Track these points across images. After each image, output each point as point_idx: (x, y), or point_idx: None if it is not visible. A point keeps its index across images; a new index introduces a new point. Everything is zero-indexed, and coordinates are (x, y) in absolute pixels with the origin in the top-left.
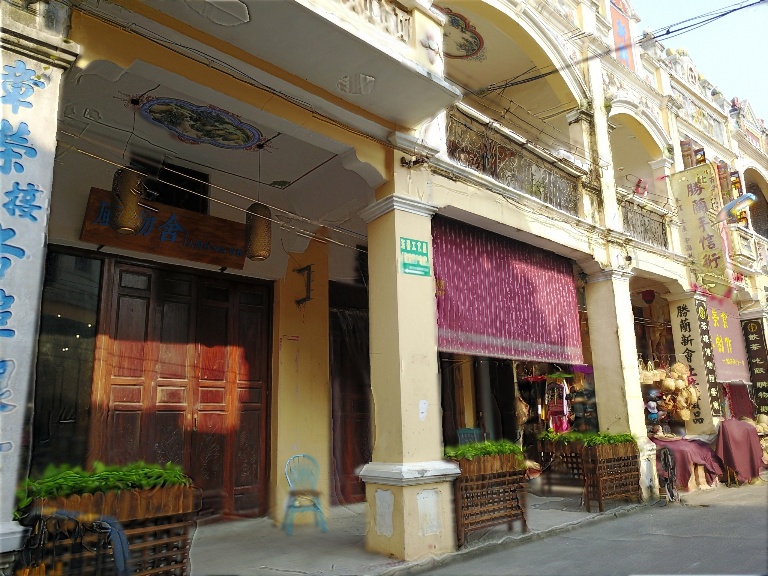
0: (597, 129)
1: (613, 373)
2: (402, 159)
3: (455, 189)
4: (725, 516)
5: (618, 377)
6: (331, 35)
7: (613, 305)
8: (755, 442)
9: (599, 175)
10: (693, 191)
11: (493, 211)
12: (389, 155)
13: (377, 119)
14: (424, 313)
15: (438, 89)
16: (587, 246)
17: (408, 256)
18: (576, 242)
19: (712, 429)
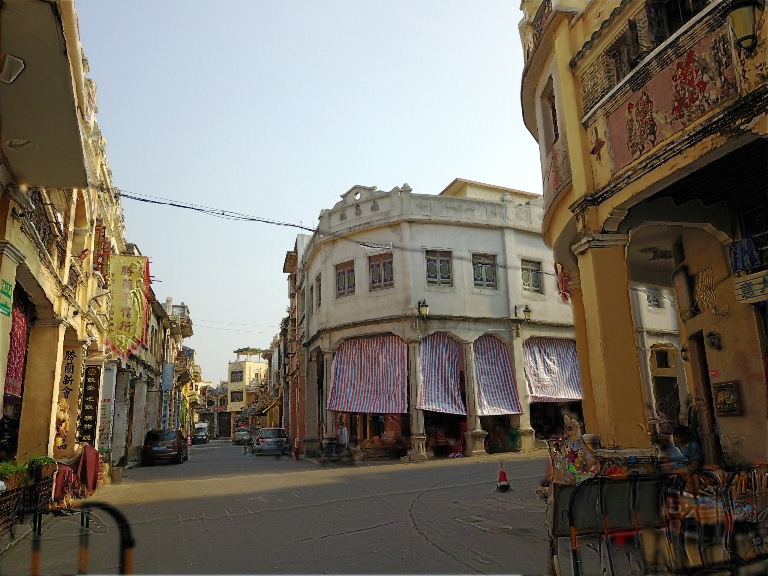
0: (73, 199)
1: (42, 406)
2: (13, 209)
3: (21, 238)
4: (119, 513)
5: (46, 409)
6: (68, 130)
7: (55, 349)
8: (97, 463)
9: (67, 238)
10: (126, 272)
11: (30, 261)
12: (5, 202)
13: (11, 171)
14: (3, 349)
15: (85, 180)
16: (53, 297)
17: (2, 297)
18: (50, 293)
19: (72, 453)
